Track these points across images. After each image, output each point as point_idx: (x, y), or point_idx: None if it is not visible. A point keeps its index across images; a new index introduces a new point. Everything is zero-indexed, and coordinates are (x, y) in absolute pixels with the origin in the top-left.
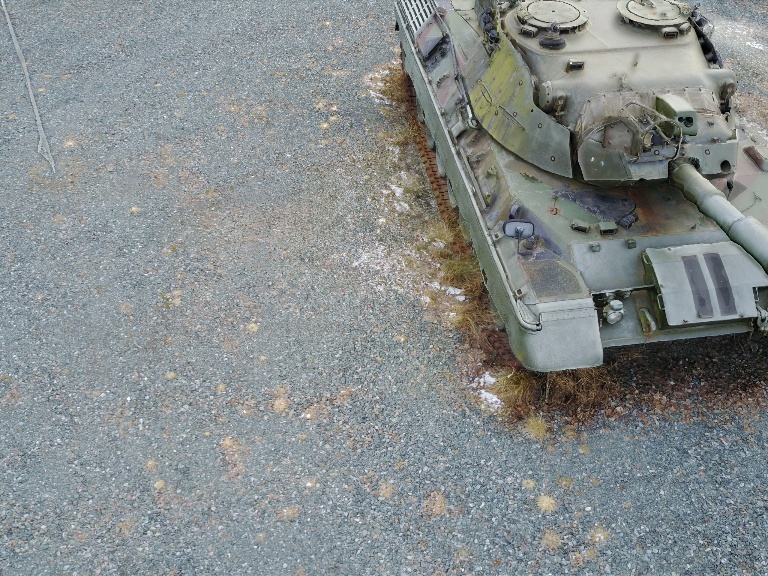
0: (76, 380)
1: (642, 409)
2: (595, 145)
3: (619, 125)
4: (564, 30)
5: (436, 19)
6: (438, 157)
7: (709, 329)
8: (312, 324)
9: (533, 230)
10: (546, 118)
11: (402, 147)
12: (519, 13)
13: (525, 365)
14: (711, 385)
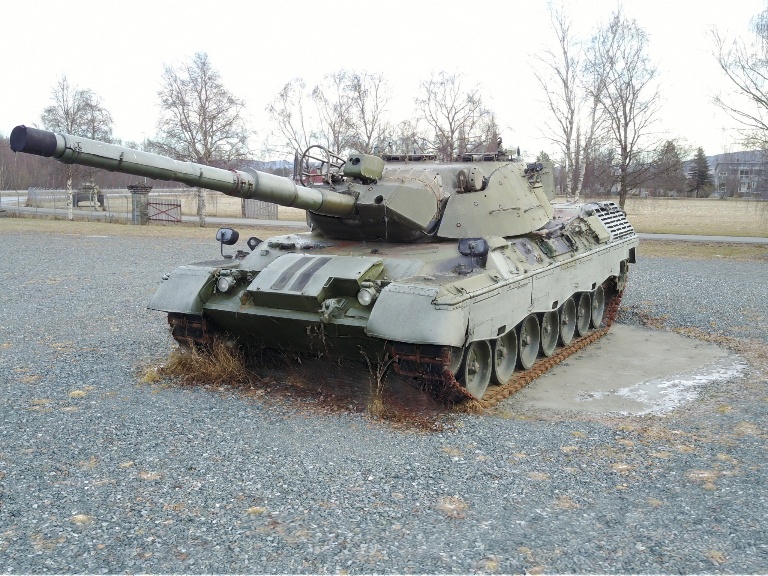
0: (6, 323)
1: None
2: None
3: None
4: (395, 157)
5: None
6: None
7: (290, 313)
8: None
9: (232, 235)
10: None
11: None
12: None
13: None
14: (316, 403)
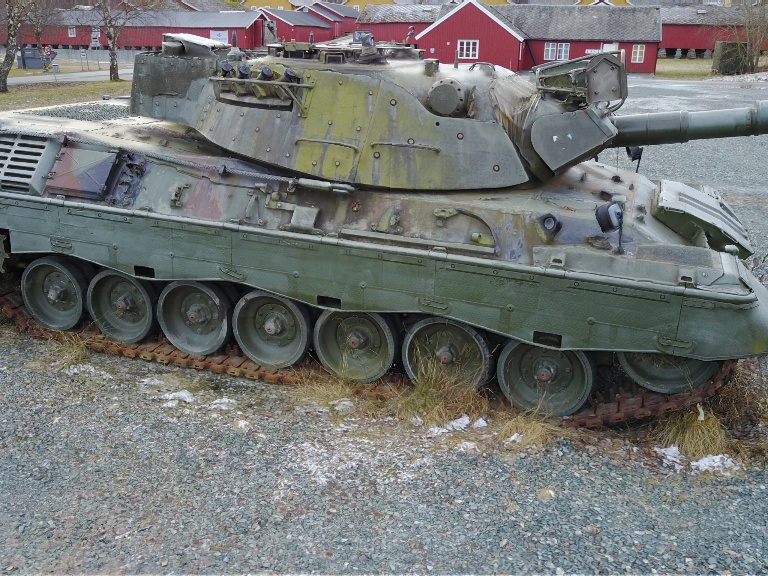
0: None
1: None
2: (553, 119)
3: (602, 66)
4: (359, 53)
5: (68, 146)
6: (175, 337)
7: None
8: (450, 575)
9: None
10: (465, 122)
11: (88, 363)
12: (300, 44)
13: None
14: None
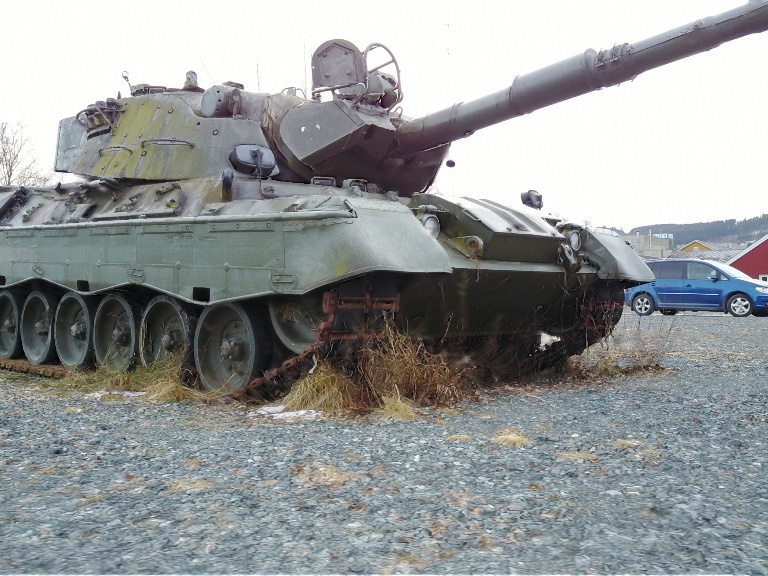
0: None
1: (507, 395)
2: (301, 111)
3: (333, 50)
4: None
5: None
6: (28, 349)
7: (527, 265)
8: None
9: None
10: (221, 120)
11: None
12: (138, 85)
13: (355, 269)
14: (547, 385)
